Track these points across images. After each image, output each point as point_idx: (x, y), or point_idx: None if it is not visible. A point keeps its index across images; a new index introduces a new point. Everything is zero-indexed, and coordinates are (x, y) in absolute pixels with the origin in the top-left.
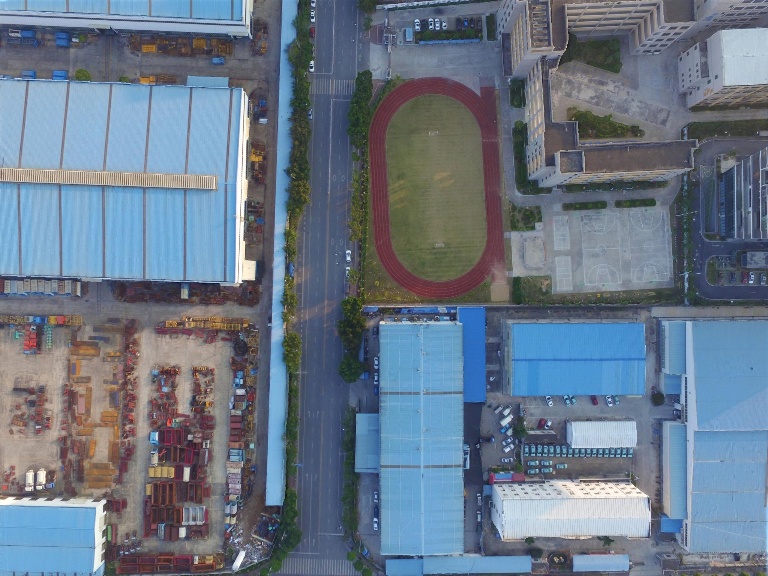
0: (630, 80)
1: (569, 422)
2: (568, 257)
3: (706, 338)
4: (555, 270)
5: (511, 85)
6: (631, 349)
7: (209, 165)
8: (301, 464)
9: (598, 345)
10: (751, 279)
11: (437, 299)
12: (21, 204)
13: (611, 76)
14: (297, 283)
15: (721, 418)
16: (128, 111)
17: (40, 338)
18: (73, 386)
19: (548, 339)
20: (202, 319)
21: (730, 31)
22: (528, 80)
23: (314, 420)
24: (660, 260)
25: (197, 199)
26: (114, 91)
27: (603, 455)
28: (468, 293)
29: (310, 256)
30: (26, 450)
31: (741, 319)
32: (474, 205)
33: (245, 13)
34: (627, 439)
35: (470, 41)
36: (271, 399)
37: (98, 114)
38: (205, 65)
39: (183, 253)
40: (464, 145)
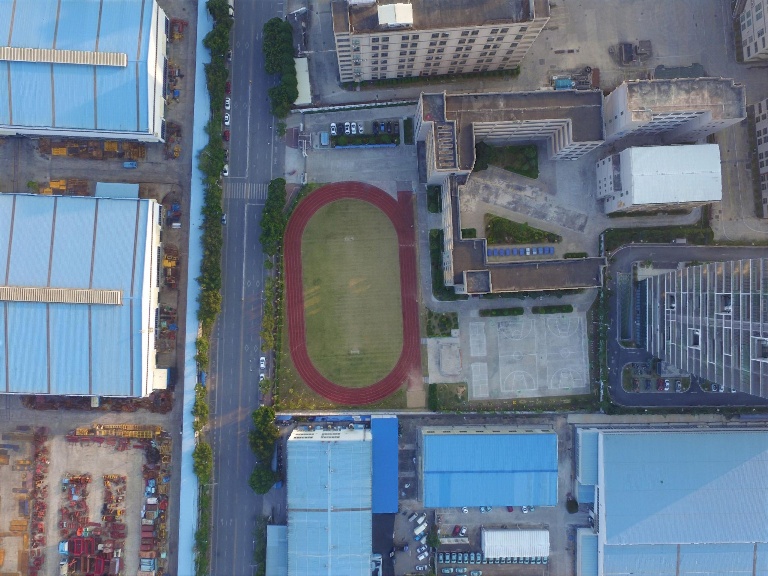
0: (548, 185)
1: (483, 530)
2: (484, 363)
3: (617, 451)
4: (471, 377)
5: None
6: (543, 460)
7: (114, 279)
8: (214, 573)
9: (510, 457)
10: (666, 387)
11: (352, 405)
12: None
13: (529, 181)
14: (210, 390)
15: (630, 532)
16: (32, 223)
17: None
18: None
19: (460, 451)
20: (113, 427)
21: (640, 149)
22: (443, 188)
23: (227, 528)
24: (576, 366)
25: (102, 314)
26: (17, 202)
27: (518, 562)
28: (384, 399)
29: (224, 362)
30: None
31: (656, 426)
32: (390, 311)
33: (153, 122)
34: (540, 549)
35: (387, 146)
36: (182, 510)
37: (1, 226)
38: (117, 168)
39: (88, 368)
40: (381, 250)
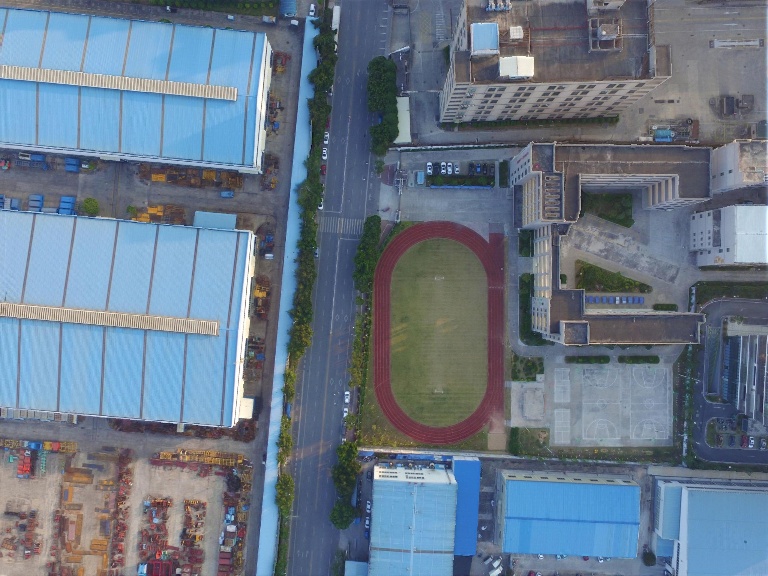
0: (641, 235)
1: None
2: (567, 410)
3: (701, 508)
4: (554, 422)
5: (520, 234)
6: (625, 512)
7: (212, 310)
8: None
9: (592, 507)
10: (751, 444)
11: (433, 445)
12: (21, 339)
13: (622, 230)
14: (294, 421)
15: None
16: (133, 250)
17: (34, 463)
18: (64, 512)
19: (542, 498)
20: (197, 453)
21: (745, 207)
22: (538, 234)
23: (303, 559)
24: (660, 418)
25: (198, 343)
26: (121, 229)
27: None
28: (465, 440)
29: (308, 395)
30: (14, 574)
31: (738, 482)
32: (476, 352)
33: (256, 155)
34: None
35: (482, 187)
36: (261, 540)
37: (103, 252)
38: (214, 197)
39: (181, 395)
40: (469, 291)
